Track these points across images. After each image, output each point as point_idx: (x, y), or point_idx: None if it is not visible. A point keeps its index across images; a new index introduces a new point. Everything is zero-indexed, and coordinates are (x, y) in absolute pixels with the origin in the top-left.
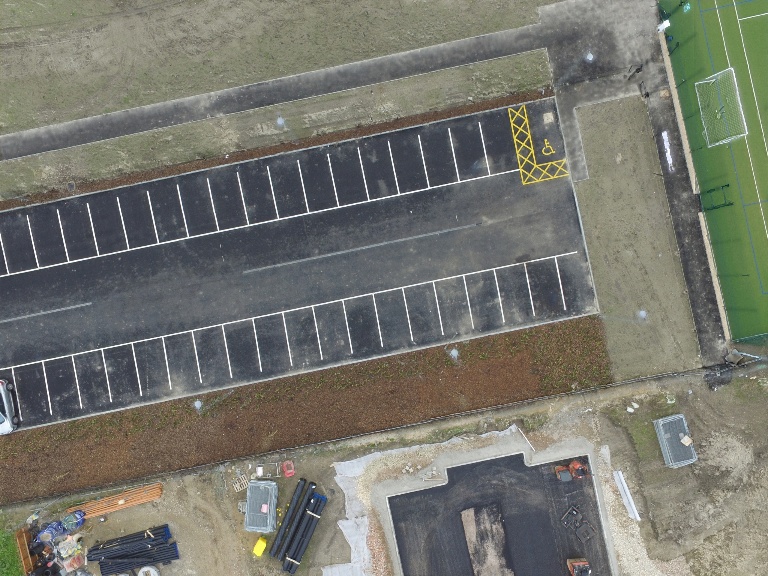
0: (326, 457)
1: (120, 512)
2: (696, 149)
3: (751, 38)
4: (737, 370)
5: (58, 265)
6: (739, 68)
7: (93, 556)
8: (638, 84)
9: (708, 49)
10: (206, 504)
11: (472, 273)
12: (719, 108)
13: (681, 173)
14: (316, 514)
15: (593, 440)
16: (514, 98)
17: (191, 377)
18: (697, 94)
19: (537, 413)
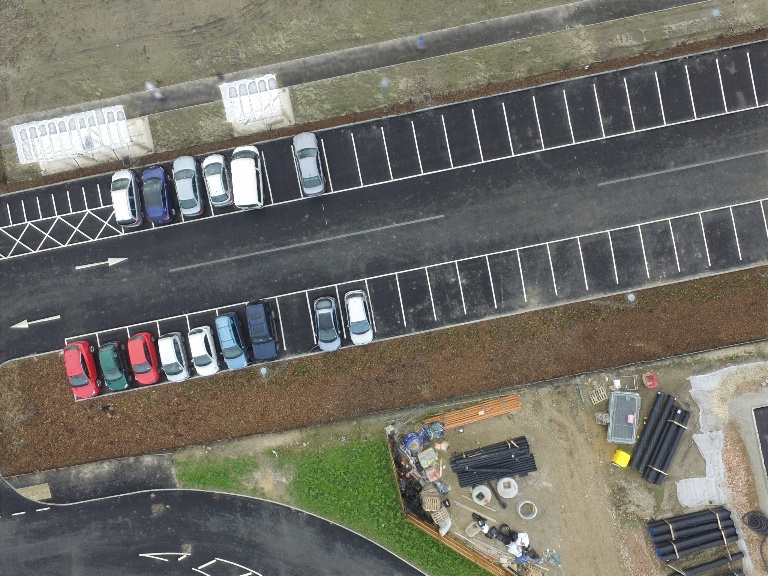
0: (683, 370)
1: (476, 424)
2: None
3: None
4: None
5: (411, 177)
6: None
7: (460, 465)
8: None
9: None
10: (562, 416)
11: None
12: None
13: None
14: (683, 424)
15: None
16: None
17: (546, 289)
18: None
19: None
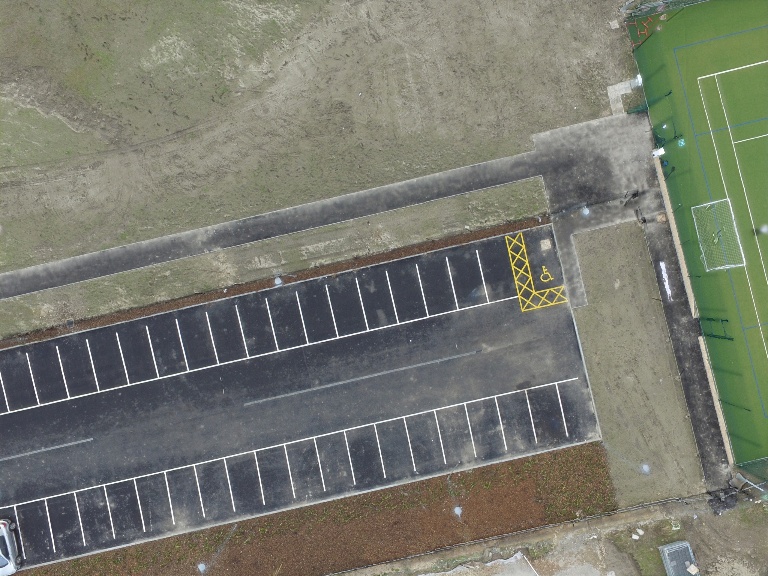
0: None
1: None
2: (694, 273)
3: (746, 161)
4: (741, 494)
5: (58, 402)
6: (735, 191)
7: None
8: (634, 210)
9: (703, 173)
10: None
11: (473, 401)
12: (716, 232)
13: (680, 297)
14: None
15: (599, 567)
16: (511, 226)
17: (194, 512)
18: (694, 218)
19: (542, 541)
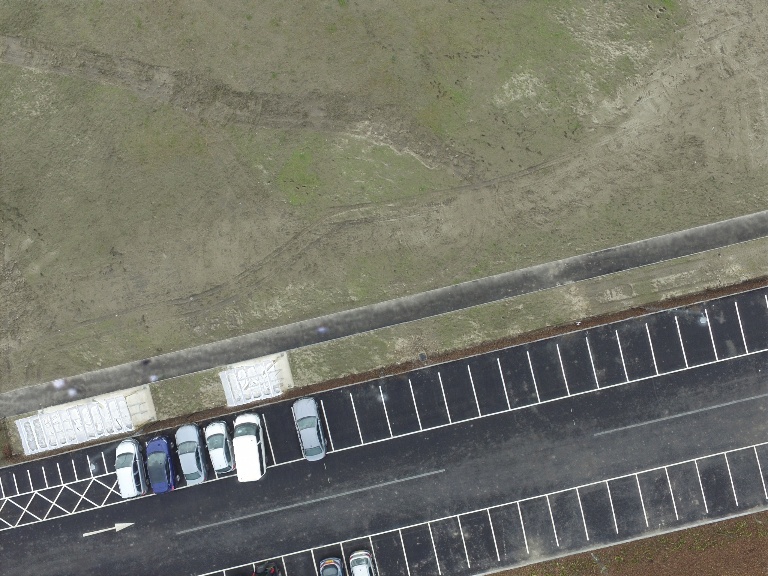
0: None
1: None
2: None
3: None
4: None
5: (411, 434)
6: None
7: None
8: None
9: None
10: None
11: None
12: None
13: None
14: None
15: None
16: None
17: (548, 541)
18: None
19: None
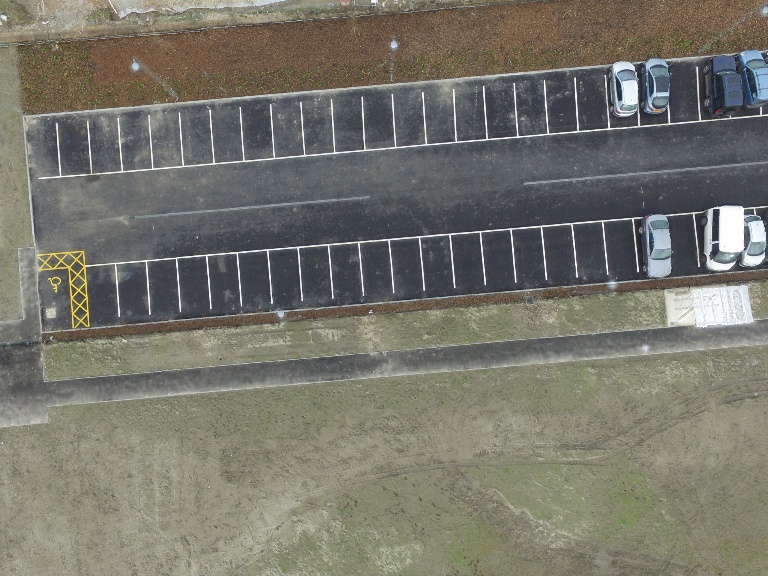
0: (308, 6)
1: None
2: None
3: None
4: None
5: (552, 225)
6: None
7: None
8: None
9: None
10: None
11: (144, 170)
12: None
13: None
14: None
15: None
16: (81, 336)
17: (432, 99)
18: None
19: (96, 26)
